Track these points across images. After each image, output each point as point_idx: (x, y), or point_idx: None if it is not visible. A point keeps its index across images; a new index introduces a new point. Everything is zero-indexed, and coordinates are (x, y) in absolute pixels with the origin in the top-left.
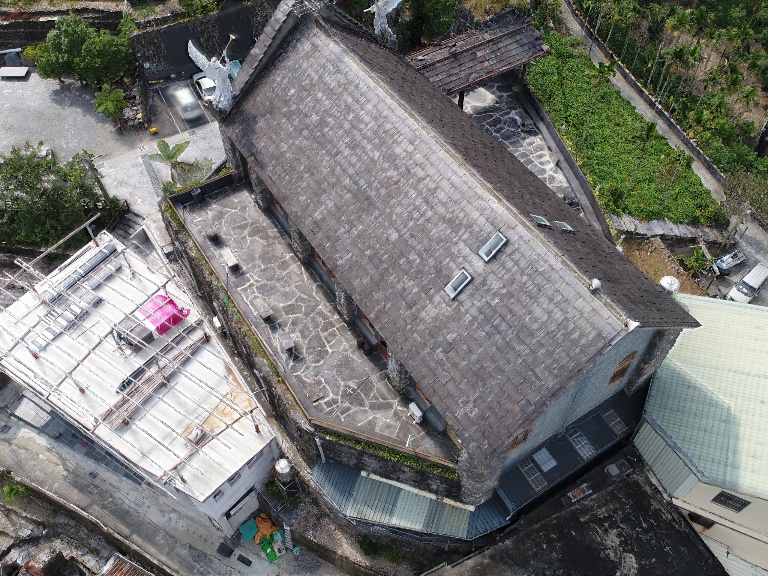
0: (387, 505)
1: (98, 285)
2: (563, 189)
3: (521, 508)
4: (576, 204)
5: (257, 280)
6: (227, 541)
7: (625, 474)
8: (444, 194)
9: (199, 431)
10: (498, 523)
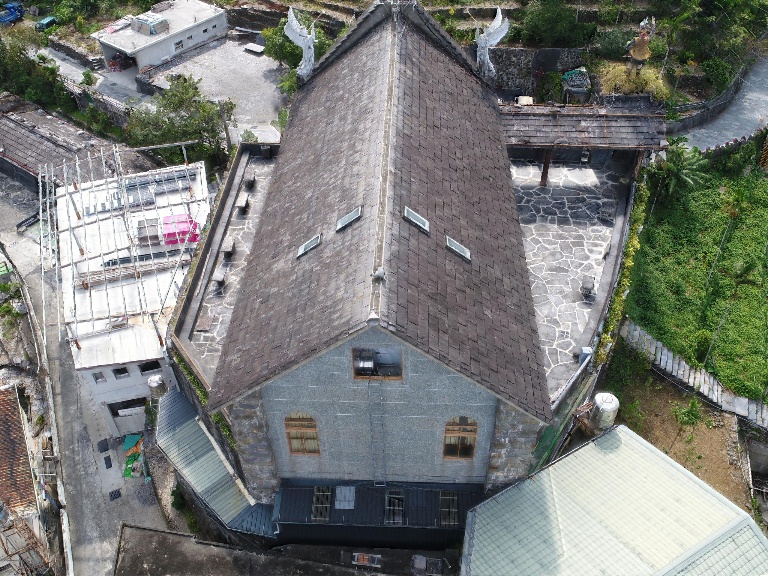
0: (192, 455)
1: (162, 192)
2: (584, 276)
3: (300, 535)
4: (592, 298)
5: (250, 227)
6: (111, 440)
7: (429, 574)
8: (358, 167)
9: (121, 318)
10: (264, 531)
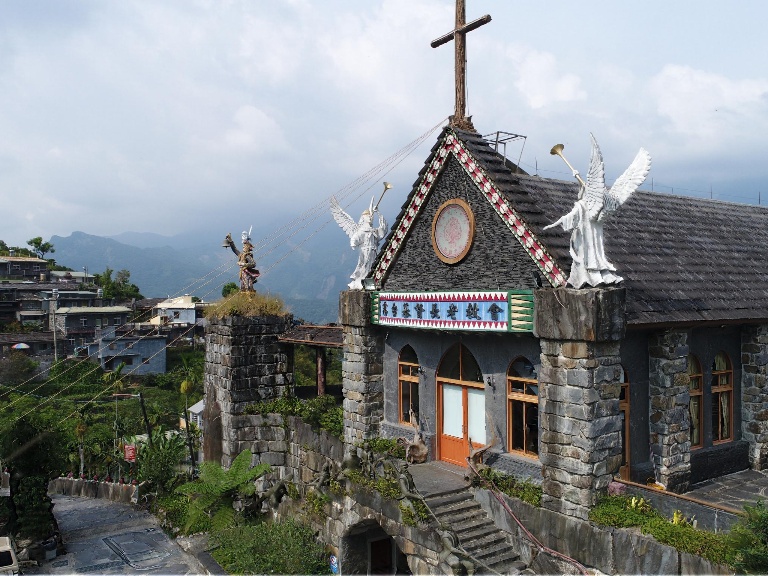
0: None
1: None
2: None
3: None
4: None
5: None
6: None
7: None
8: None
9: None
10: None
